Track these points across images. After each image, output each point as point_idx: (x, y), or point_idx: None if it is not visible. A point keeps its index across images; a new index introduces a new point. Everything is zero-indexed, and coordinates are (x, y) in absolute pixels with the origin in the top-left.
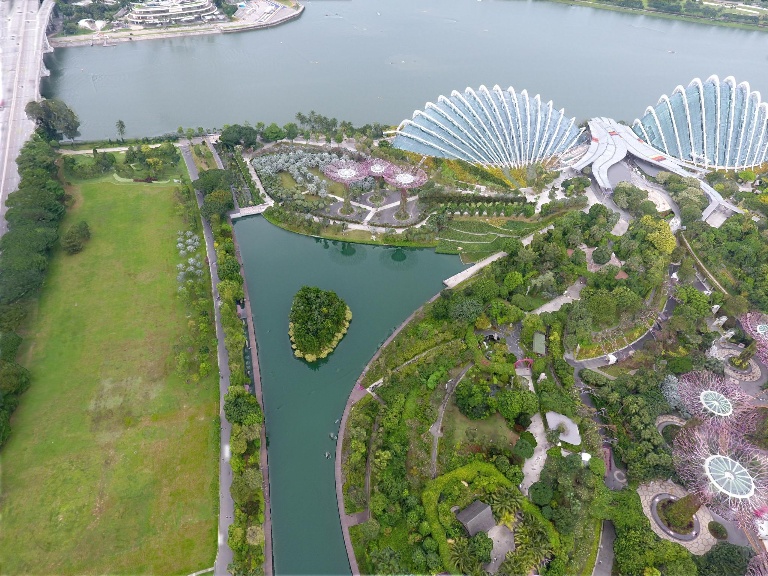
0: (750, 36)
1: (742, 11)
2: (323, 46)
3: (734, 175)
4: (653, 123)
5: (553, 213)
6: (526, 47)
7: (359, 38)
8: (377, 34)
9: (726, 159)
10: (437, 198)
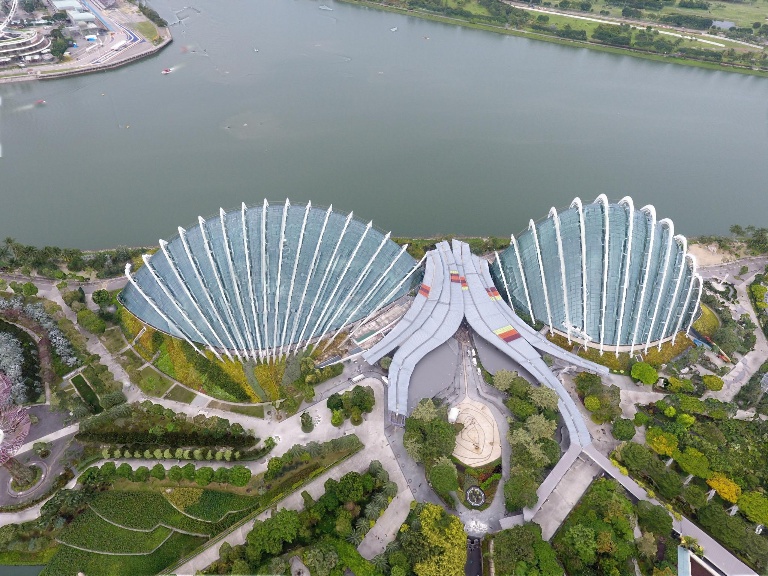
0: (712, 76)
1: (705, 43)
2: (156, 99)
3: (628, 363)
4: (515, 263)
5: (294, 469)
6: (420, 99)
7: (212, 86)
8: (239, 79)
9: (617, 335)
10: (101, 438)
